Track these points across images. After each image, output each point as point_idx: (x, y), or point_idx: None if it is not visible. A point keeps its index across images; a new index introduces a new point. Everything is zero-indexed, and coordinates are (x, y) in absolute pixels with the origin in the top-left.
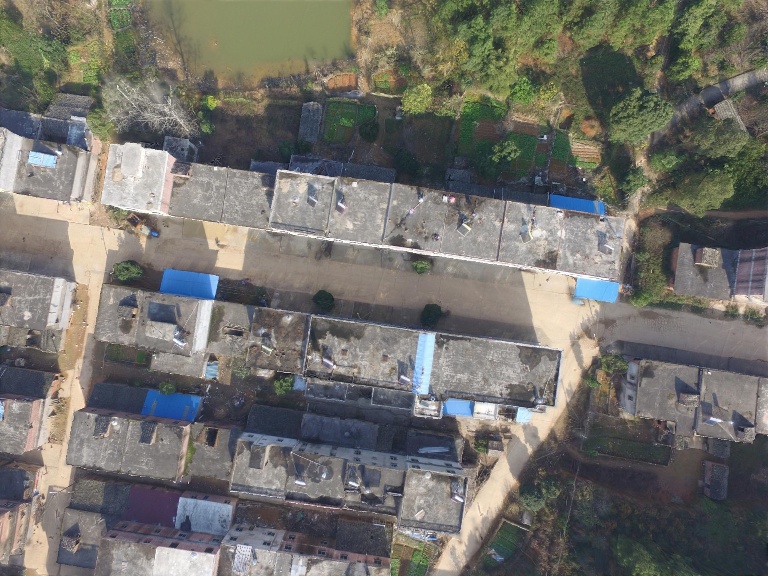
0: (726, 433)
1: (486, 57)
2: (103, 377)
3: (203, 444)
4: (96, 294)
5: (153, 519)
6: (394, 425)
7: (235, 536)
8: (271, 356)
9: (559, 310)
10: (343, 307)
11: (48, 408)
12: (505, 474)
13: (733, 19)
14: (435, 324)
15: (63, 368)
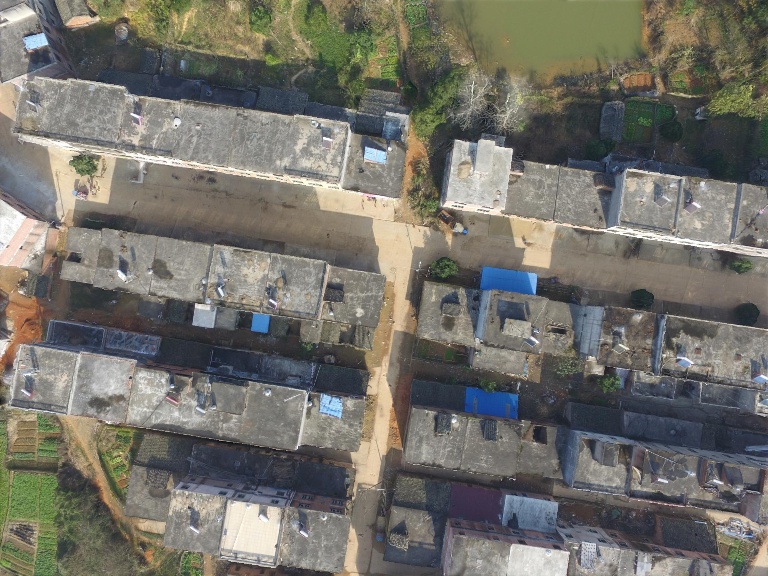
0: None
1: None
2: (411, 374)
3: (530, 442)
4: (402, 291)
5: (480, 516)
6: (711, 423)
7: (568, 533)
8: (622, 354)
9: None
10: (653, 306)
11: None
12: None
13: None
14: None
15: (370, 365)
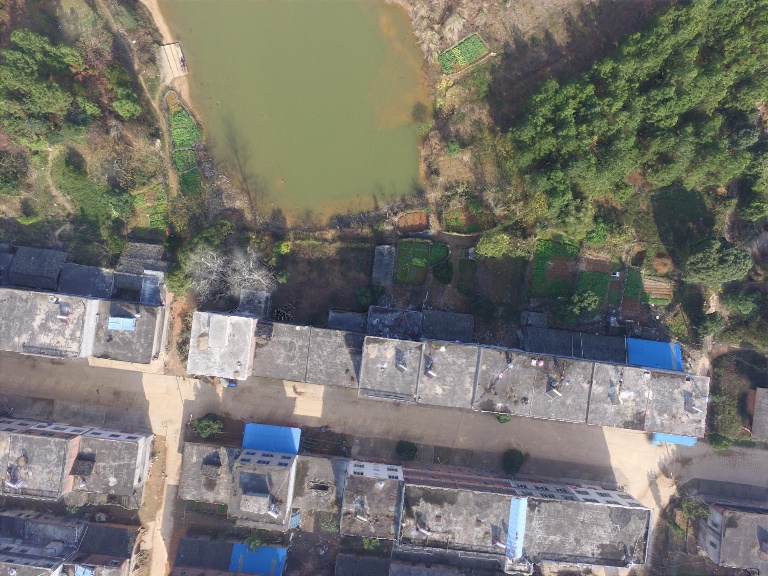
0: None
1: (565, 207)
2: (185, 528)
3: None
4: (174, 445)
5: None
6: (479, 570)
7: None
8: (365, 523)
9: (636, 450)
10: (423, 452)
11: (132, 564)
12: None
13: None
14: None
15: (144, 520)
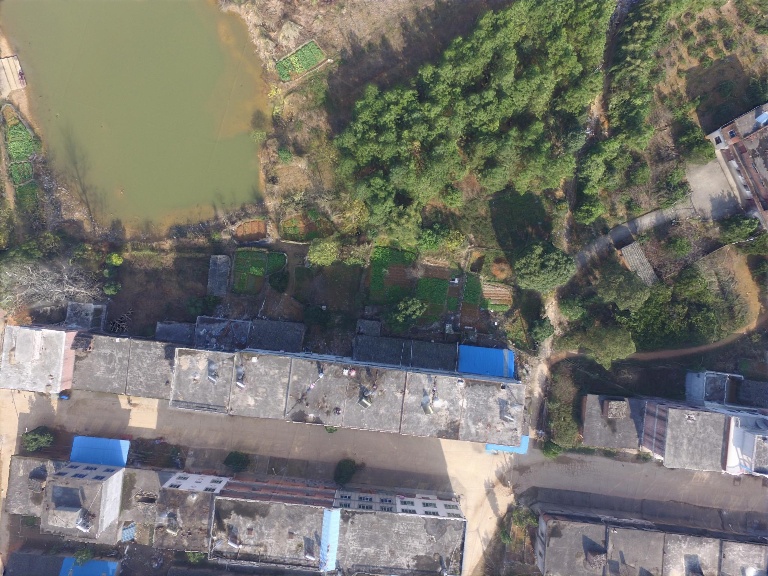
0: None
1: (388, 214)
2: (20, 542)
3: None
4: (9, 458)
5: None
6: None
7: None
8: (177, 536)
9: (473, 458)
10: (258, 463)
11: None
12: None
13: (640, 157)
14: (349, 480)
15: None
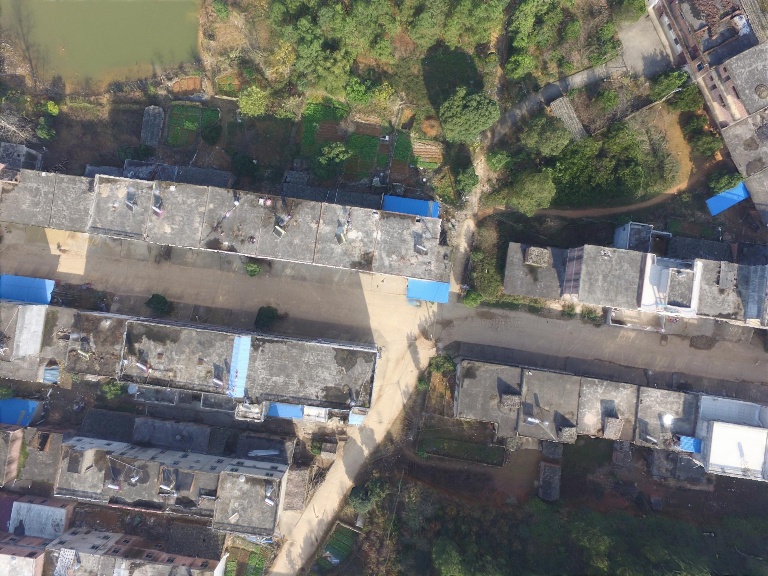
0: (548, 434)
1: (315, 58)
2: None
3: (36, 448)
4: None
5: None
6: (229, 428)
7: (65, 540)
8: (90, 360)
9: (396, 311)
10: (182, 310)
11: None
12: (341, 476)
13: (572, 16)
14: (269, 327)
15: None
